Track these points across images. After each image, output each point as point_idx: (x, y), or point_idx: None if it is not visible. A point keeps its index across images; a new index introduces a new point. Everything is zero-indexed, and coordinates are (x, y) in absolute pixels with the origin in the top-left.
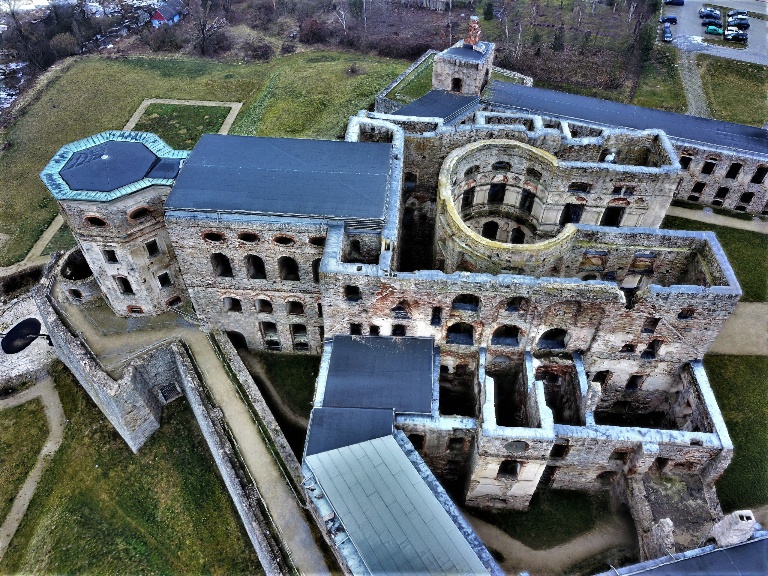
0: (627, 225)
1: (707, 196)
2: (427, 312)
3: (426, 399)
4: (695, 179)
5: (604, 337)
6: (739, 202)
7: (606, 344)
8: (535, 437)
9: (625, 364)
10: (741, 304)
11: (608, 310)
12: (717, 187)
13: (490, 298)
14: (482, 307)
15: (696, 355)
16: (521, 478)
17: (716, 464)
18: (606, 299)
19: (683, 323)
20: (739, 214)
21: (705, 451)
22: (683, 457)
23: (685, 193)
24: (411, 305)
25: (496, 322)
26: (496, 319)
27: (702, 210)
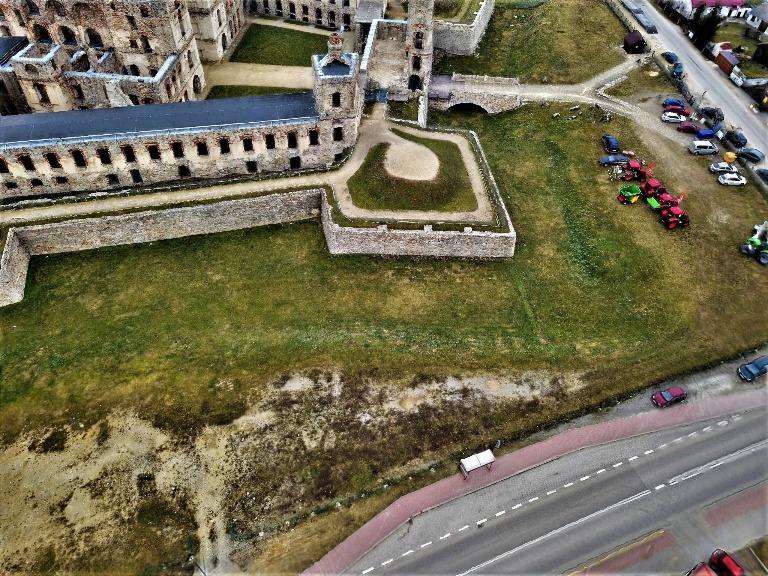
0: (189, 0)
1: (311, 16)
2: (12, 14)
3: (0, 56)
4: (300, 3)
5: (115, 34)
6: (331, 20)
7: (119, 40)
8: (35, 61)
9: (139, 58)
10: (285, 66)
11: (104, 10)
12: (314, 8)
13: (38, 1)
14: (39, 10)
15: (172, 49)
16: (53, 103)
17: (154, 94)
18: (98, 1)
19: (148, 21)
20: (330, 28)
21: (147, 86)
22: (141, 93)
23: (299, 15)
24: (1, 8)
25: (55, 24)
26: (54, 22)
27: (307, 26)
